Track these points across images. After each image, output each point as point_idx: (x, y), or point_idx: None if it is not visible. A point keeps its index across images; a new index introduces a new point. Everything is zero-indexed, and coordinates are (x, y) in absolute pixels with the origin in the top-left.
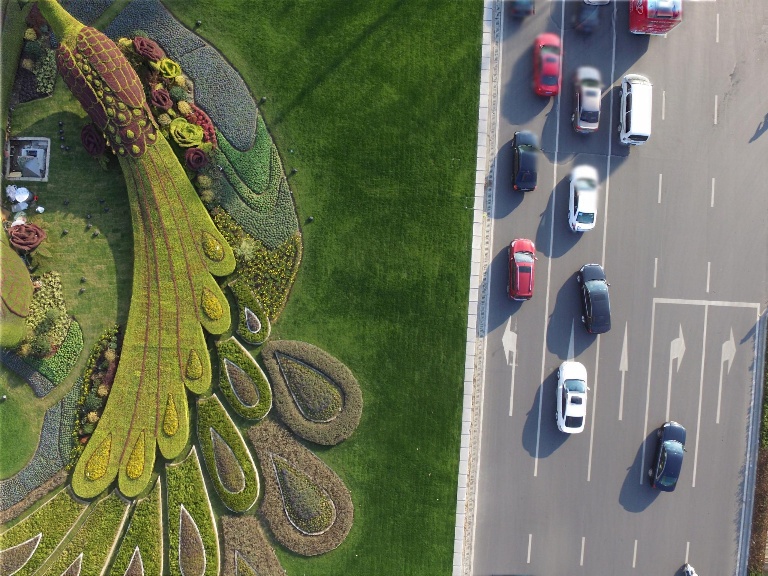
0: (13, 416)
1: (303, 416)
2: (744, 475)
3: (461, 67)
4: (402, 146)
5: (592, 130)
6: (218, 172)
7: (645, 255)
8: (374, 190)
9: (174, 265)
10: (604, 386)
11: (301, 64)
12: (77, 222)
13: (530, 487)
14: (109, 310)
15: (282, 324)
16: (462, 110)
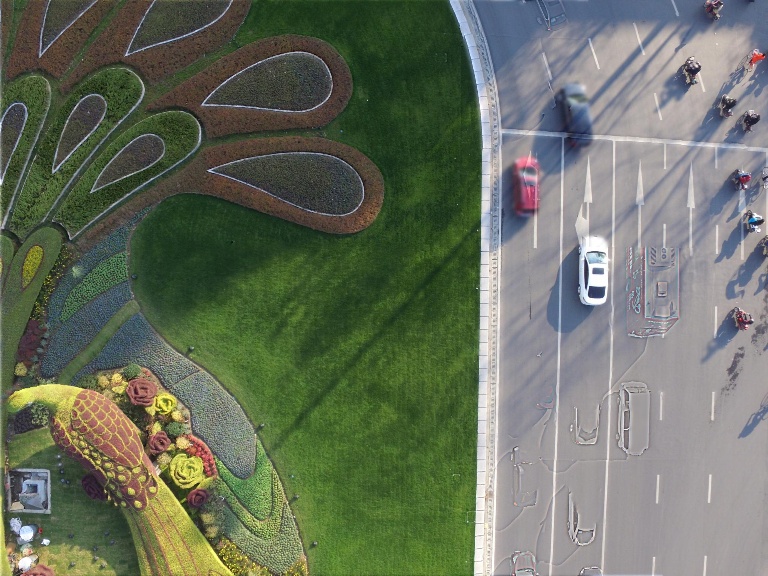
0: None
1: None
2: None
3: (458, 381)
4: (402, 466)
5: (590, 444)
6: (220, 502)
7: (643, 555)
8: (376, 512)
9: None
10: None
11: (297, 388)
12: (83, 554)
13: None
14: None
15: None
16: (461, 425)
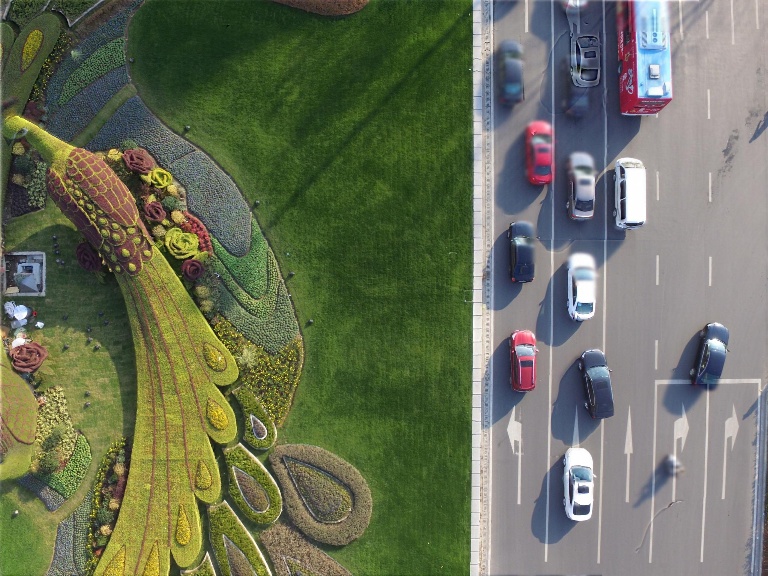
0: (26, 530)
1: (314, 518)
2: (751, 547)
3: (453, 159)
4: (398, 243)
5: (587, 218)
6: (216, 279)
7: (645, 338)
8: (372, 289)
9: (177, 378)
10: (610, 470)
11: (293, 165)
12: (77, 336)
13: (541, 573)
14: (115, 423)
15: (288, 428)
16: (456, 203)
